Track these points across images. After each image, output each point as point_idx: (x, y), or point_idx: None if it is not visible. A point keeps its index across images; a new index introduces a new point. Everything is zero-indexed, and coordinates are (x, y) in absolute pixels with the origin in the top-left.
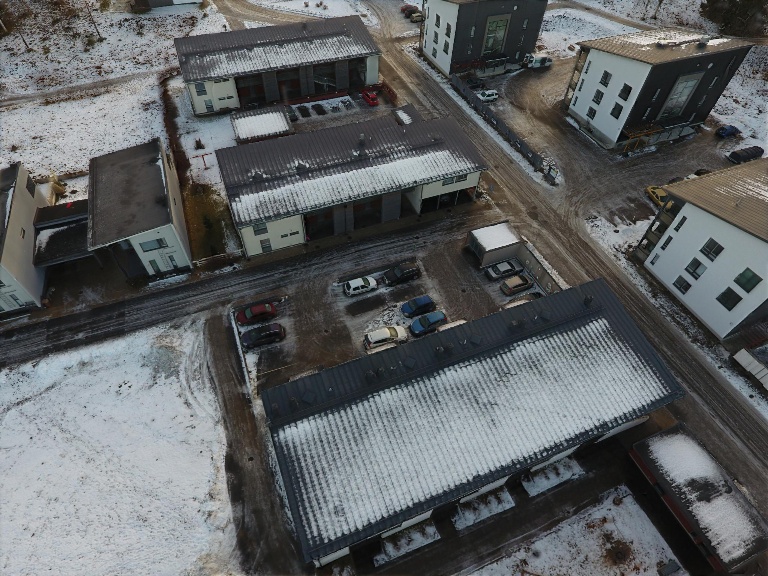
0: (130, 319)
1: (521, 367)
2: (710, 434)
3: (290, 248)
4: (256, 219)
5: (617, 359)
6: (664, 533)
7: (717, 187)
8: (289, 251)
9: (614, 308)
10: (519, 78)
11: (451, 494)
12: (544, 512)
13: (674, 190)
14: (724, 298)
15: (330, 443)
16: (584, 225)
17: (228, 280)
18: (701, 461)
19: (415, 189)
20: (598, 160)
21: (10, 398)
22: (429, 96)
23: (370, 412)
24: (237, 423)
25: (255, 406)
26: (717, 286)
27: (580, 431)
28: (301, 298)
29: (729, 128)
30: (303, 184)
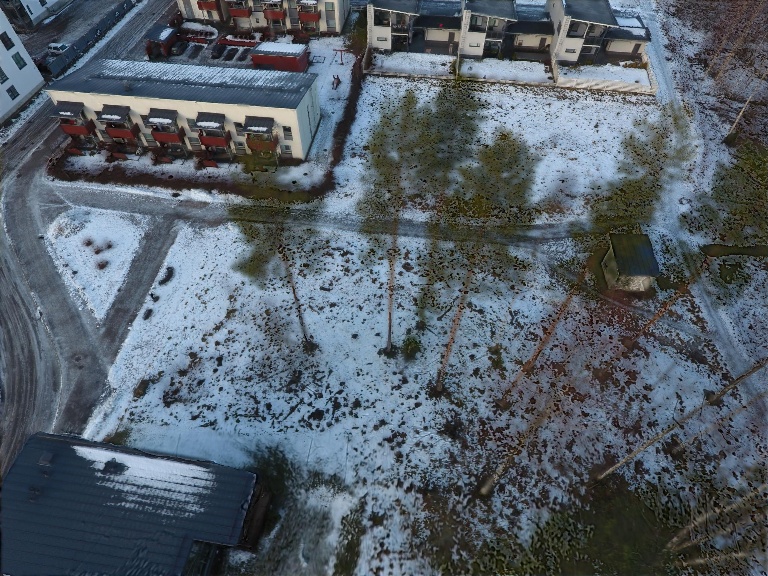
0: None
1: None
2: None
3: None
4: None
5: None
6: None
7: None
8: None
9: None
10: None
11: None
12: None
13: None
14: None
15: None
16: None
17: (365, 5)
18: None
19: None
20: None
21: None
22: None
23: None
24: None
25: None
26: None
27: None
28: None
29: None
30: None
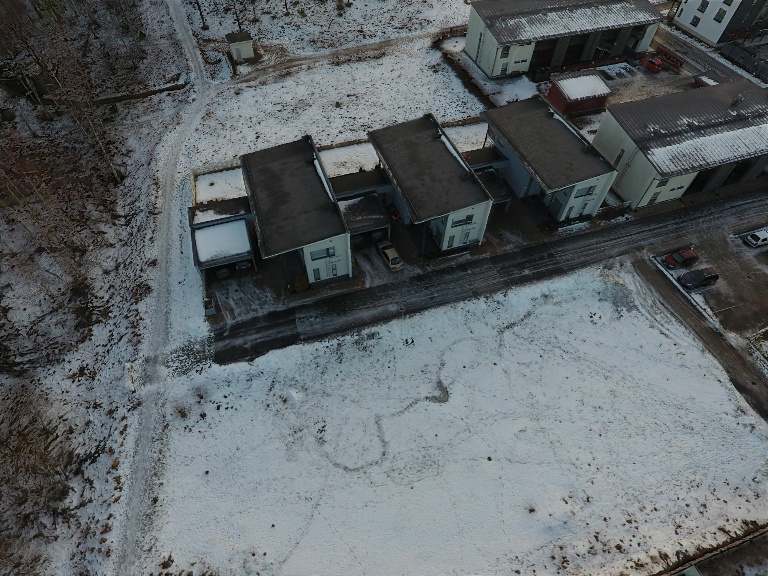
0: (562, 259)
1: None
2: None
3: (667, 202)
4: (676, 171)
5: None
6: None
7: None
8: (668, 205)
9: None
10: None
11: None
12: None
13: None
14: None
15: None
16: None
17: (628, 229)
18: None
19: None
20: None
21: (497, 322)
22: (704, 64)
23: None
24: (722, 353)
25: (730, 339)
26: None
27: None
28: (707, 247)
29: None
30: (701, 140)
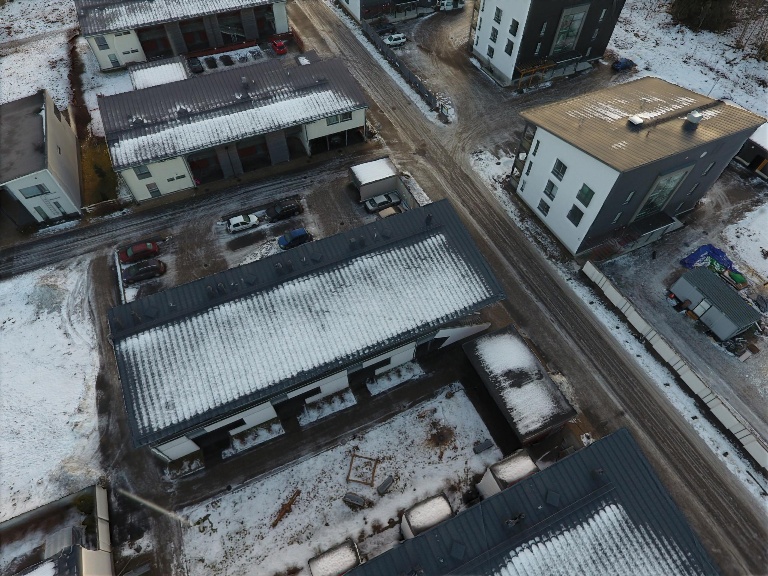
0: (18, 263)
1: (356, 279)
2: (546, 336)
3: (180, 192)
4: (134, 162)
5: (448, 269)
6: (486, 419)
7: (569, 111)
8: (179, 195)
9: (453, 225)
10: (431, 21)
11: (275, 388)
12: (382, 407)
13: (528, 116)
14: (572, 215)
15: (168, 350)
16: (468, 159)
17: (116, 224)
18: (521, 355)
19: (302, 130)
20: (493, 98)
21: None
22: (339, 43)
23: (208, 323)
24: (111, 348)
25: None
26: (566, 204)
27: (402, 331)
28: (185, 237)
29: (623, 61)
30: (183, 128)
